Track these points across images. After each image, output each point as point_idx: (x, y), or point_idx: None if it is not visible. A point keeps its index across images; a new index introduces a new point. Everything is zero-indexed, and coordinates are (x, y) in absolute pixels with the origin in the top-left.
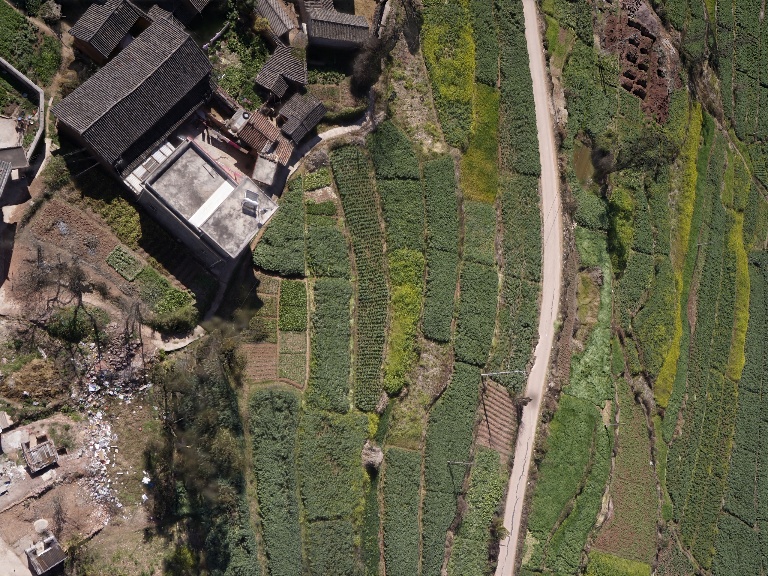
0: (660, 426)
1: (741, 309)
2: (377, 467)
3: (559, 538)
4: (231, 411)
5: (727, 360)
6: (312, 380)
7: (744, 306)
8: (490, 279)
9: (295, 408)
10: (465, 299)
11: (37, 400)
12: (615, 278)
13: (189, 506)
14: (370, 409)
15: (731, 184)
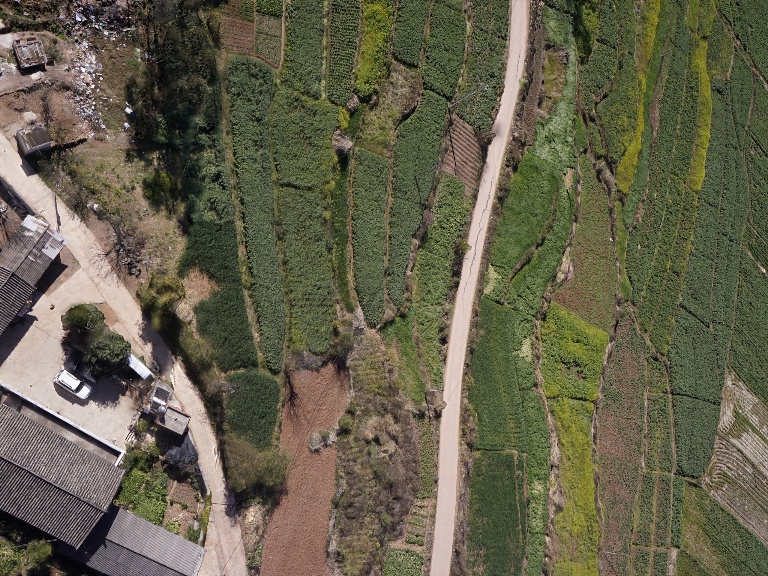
0: (621, 211)
1: (703, 128)
2: (347, 153)
3: (520, 280)
4: (209, 62)
5: (688, 170)
6: (286, 63)
7: (706, 126)
8: (458, 22)
9: (270, 78)
10: (434, 34)
11: (27, 11)
12: (580, 62)
13: (168, 137)
14: (341, 104)
15: (696, 11)
